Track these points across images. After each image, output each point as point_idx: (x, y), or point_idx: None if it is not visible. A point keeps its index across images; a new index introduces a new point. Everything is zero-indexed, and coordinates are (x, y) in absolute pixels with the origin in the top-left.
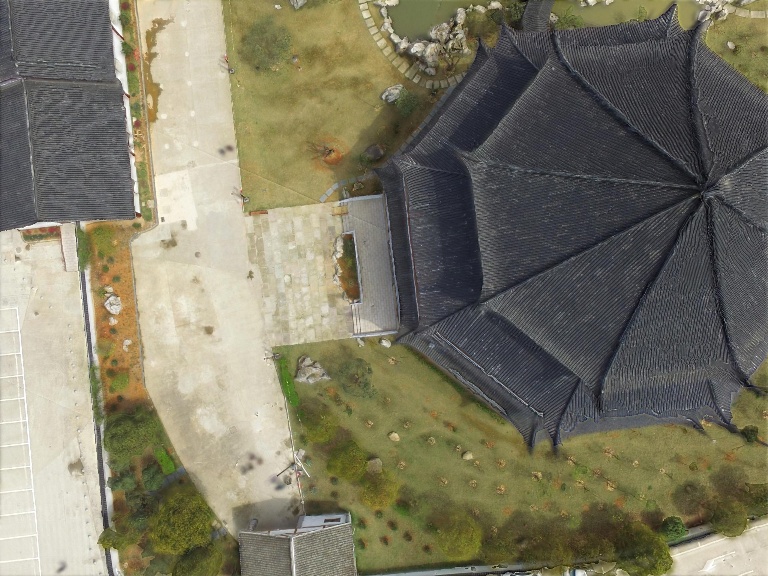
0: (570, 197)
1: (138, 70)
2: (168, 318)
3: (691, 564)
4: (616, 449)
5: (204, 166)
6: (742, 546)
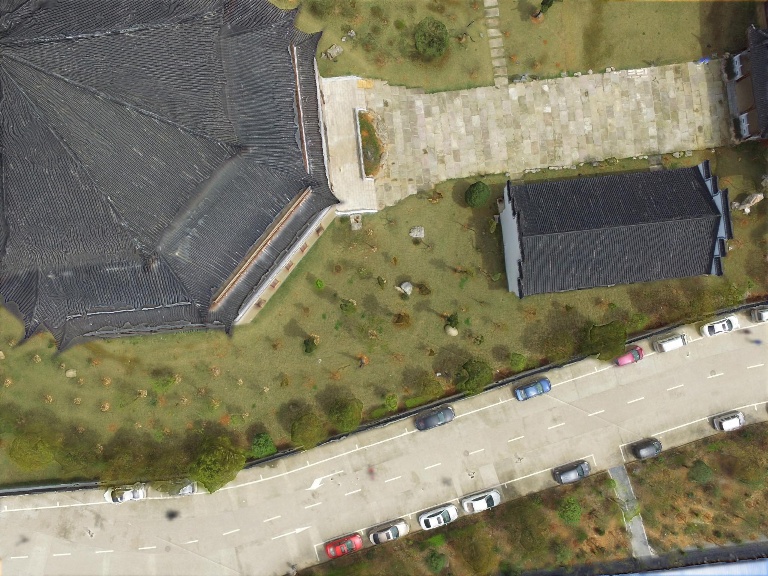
0: None
1: None
2: None
3: (298, 482)
4: (222, 368)
5: None
6: (350, 465)
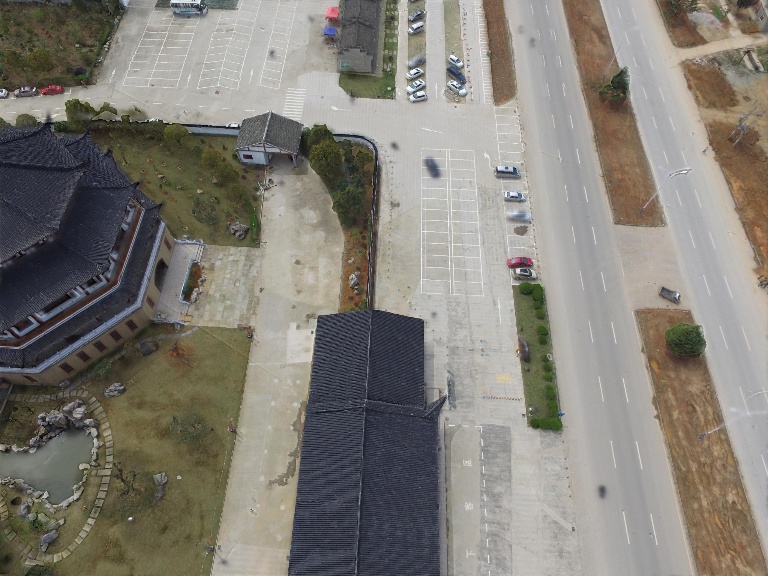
0: (7, 191)
1: None
2: (322, 273)
3: (63, 118)
4: None
5: (274, 364)
6: None
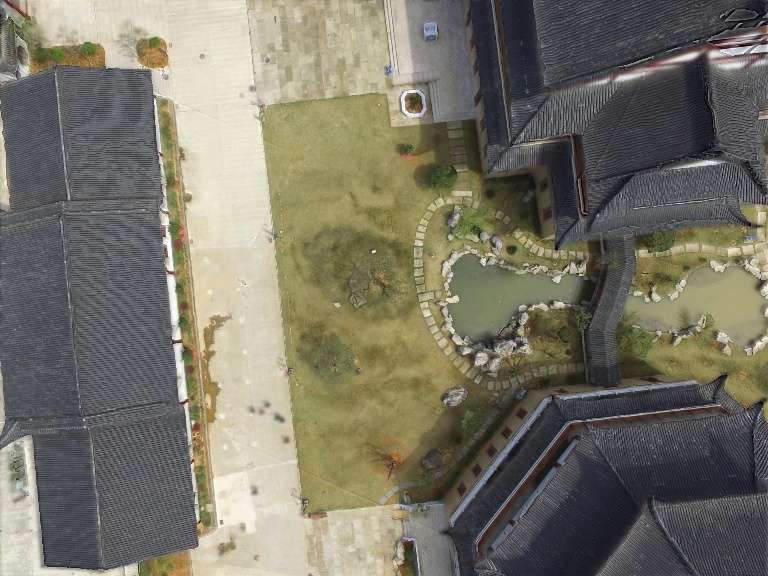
0: None
1: (196, 370)
2: None
3: None
4: None
5: (263, 467)
6: None
